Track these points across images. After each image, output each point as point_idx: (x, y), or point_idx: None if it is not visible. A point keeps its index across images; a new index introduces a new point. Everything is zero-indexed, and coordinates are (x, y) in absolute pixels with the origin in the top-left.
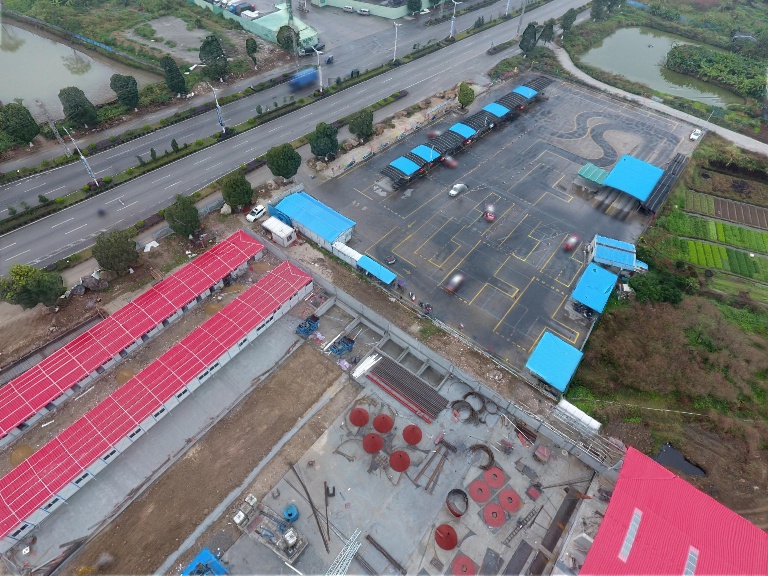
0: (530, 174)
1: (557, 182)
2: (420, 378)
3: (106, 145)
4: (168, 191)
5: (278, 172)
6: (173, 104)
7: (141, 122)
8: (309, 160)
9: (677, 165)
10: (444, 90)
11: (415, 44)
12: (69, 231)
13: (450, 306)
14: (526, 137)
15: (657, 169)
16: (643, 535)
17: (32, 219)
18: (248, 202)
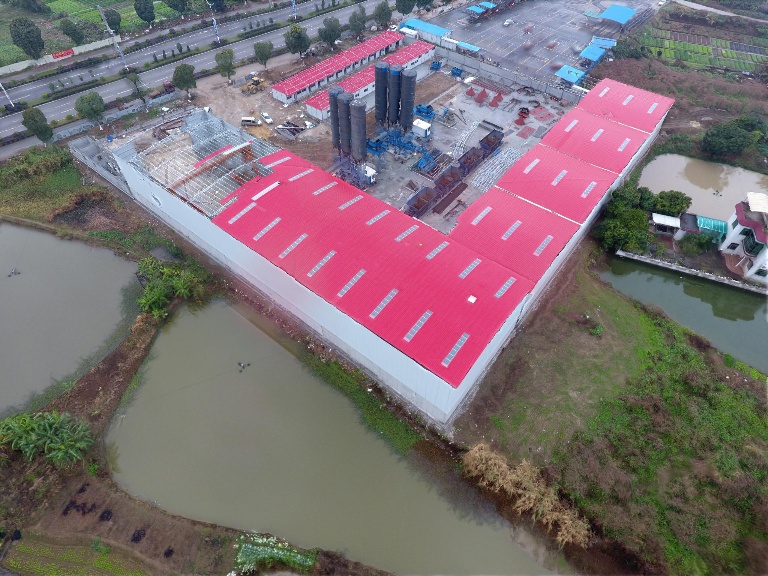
0: (553, 18)
1: (570, 21)
2: (499, 82)
3: (290, 3)
4: None
5: (403, 7)
6: None
7: None
8: (414, 11)
9: (647, 12)
10: None
11: None
12: None
13: (511, 64)
14: (549, 3)
15: (633, 10)
16: (610, 92)
17: (267, 31)
18: (386, 25)
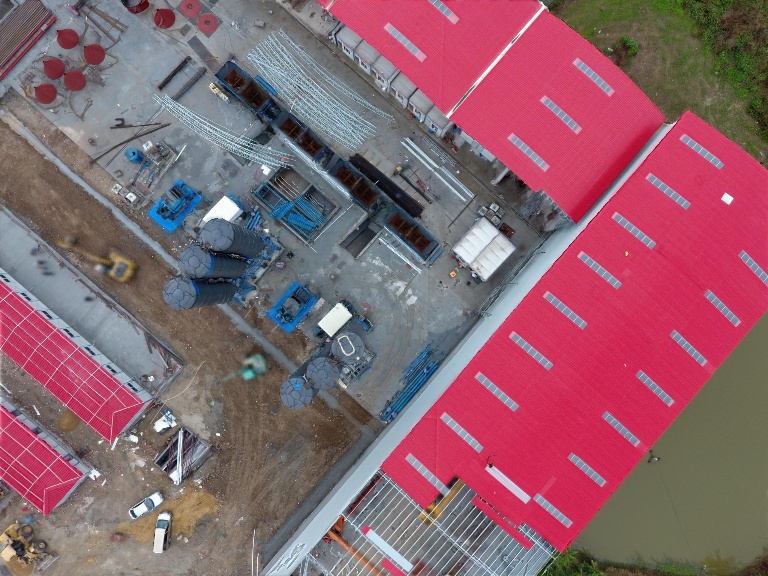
0: None
1: None
2: (0, 21)
3: None
4: None
5: None
6: None
7: None
8: None
9: None
10: None
11: None
12: None
13: None
14: None
15: None
16: None
17: None
18: None
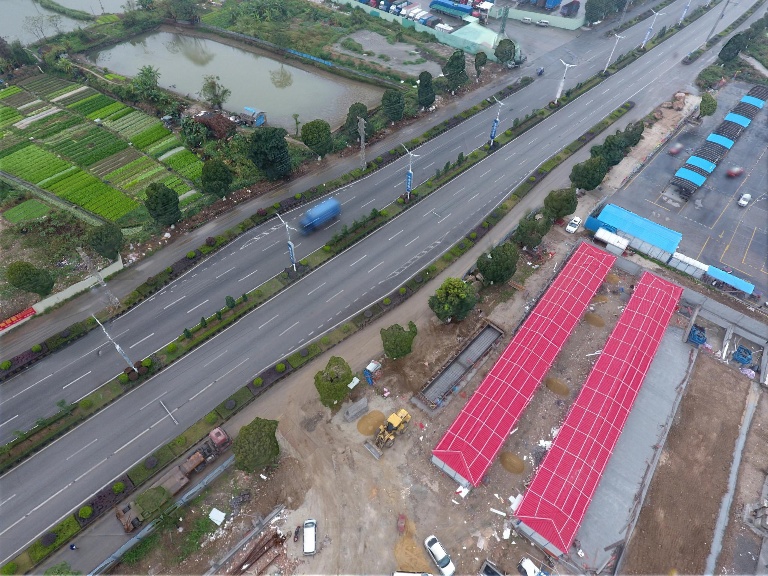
0: None
1: None
2: None
3: (389, 158)
4: (473, 203)
5: (588, 184)
6: (422, 117)
7: (404, 135)
8: None
9: None
10: (665, 100)
11: (620, 55)
12: (407, 243)
13: None
14: None
15: None
16: None
17: (368, 232)
18: None
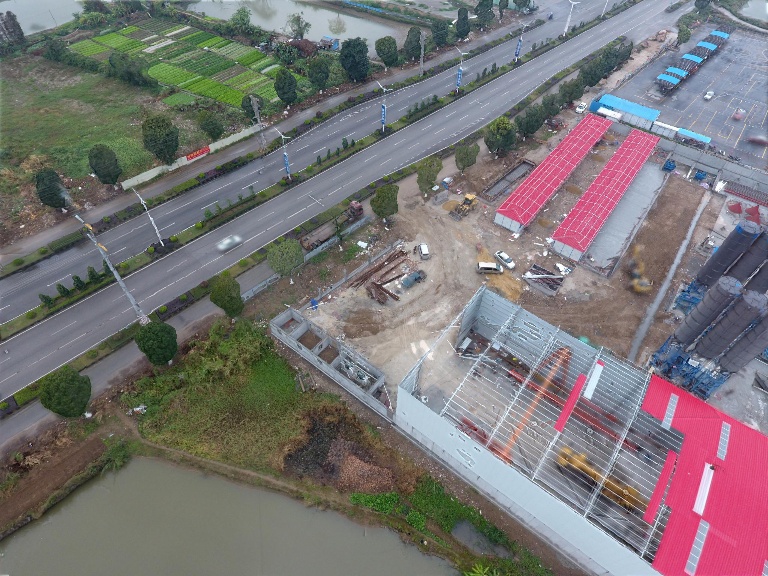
0: (753, 87)
1: None
2: (761, 191)
3: (439, 70)
4: (505, 97)
5: (591, 80)
6: (459, 46)
7: (447, 57)
8: None
9: None
10: None
11: None
12: (460, 119)
13: (750, 159)
14: (734, 65)
15: None
16: None
17: (431, 111)
18: (571, 102)
